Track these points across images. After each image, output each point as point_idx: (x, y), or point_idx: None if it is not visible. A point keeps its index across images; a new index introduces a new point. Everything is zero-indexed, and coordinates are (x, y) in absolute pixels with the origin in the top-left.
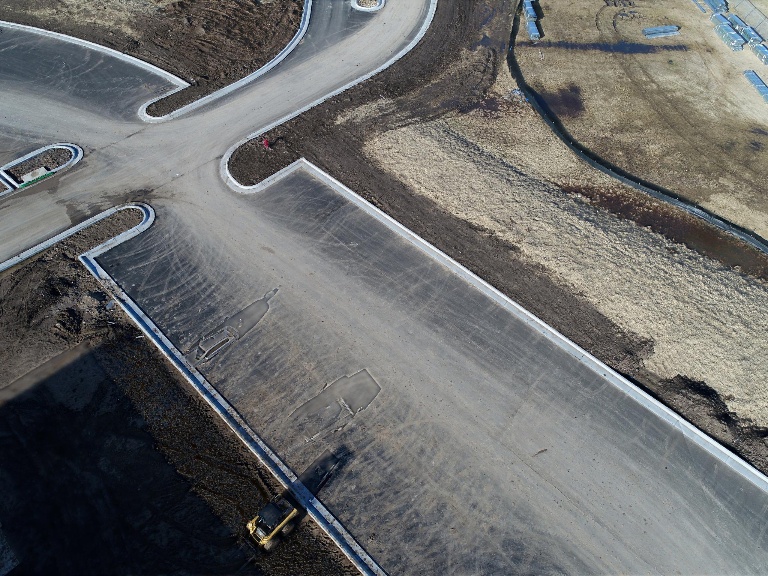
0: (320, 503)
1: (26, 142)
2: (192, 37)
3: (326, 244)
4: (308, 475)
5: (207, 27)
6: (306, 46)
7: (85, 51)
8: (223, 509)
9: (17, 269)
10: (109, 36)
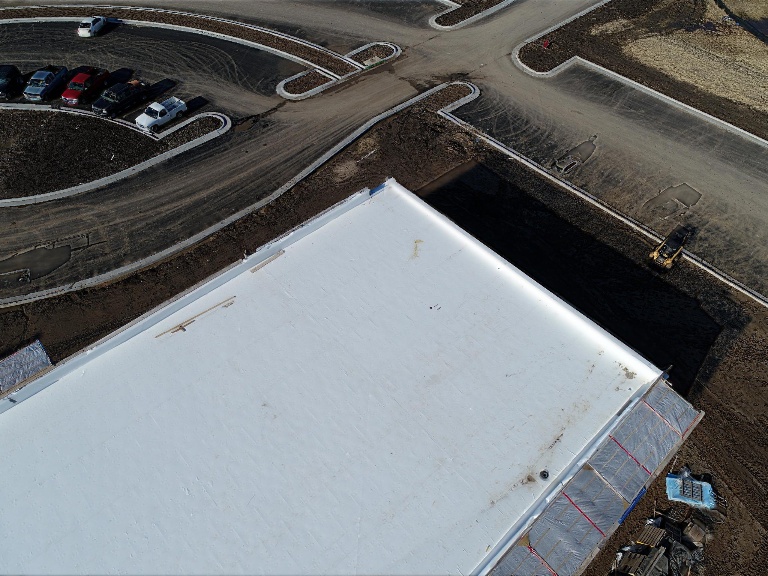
0: (688, 251)
1: (353, 40)
2: None
3: (620, 110)
4: (672, 237)
5: None
6: None
7: None
8: (623, 250)
9: (396, 117)
10: None
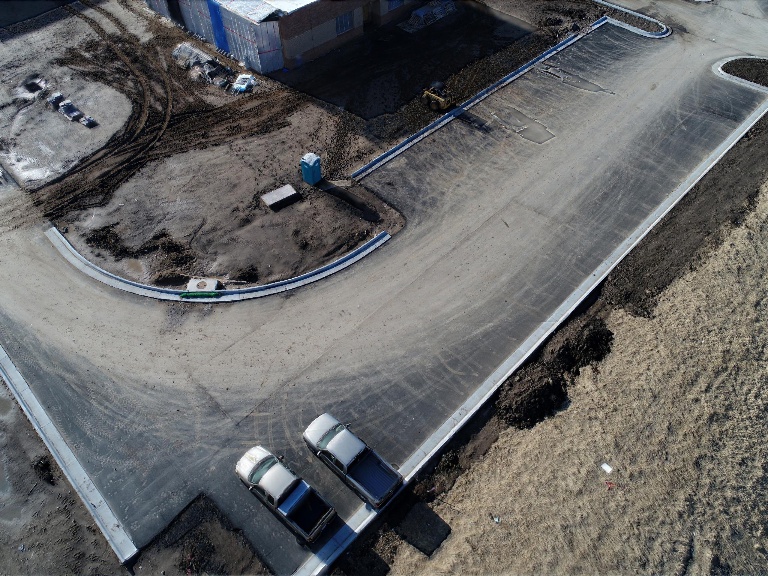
0: (452, 119)
1: None
2: None
3: (676, 113)
4: (469, 114)
5: None
6: None
7: None
8: None
9: None
10: None
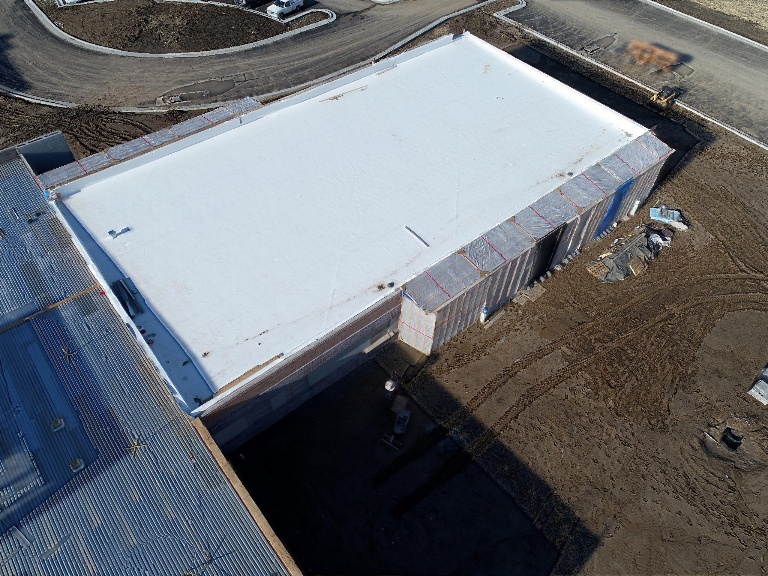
0: (680, 100)
1: None
2: None
3: (637, 18)
4: None
5: None
6: None
7: None
8: (631, 98)
9: None
10: None
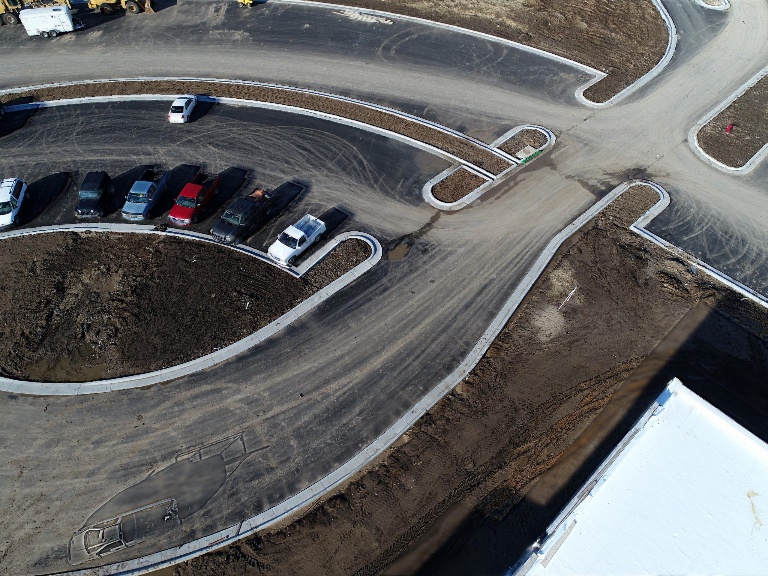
0: None
1: (495, 123)
2: (575, 30)
3: None
4: None
5: (586, 21)
6: (686, 41)
7: (483, 41)
8: None
9: (581, 235)
10: (498, 28)
